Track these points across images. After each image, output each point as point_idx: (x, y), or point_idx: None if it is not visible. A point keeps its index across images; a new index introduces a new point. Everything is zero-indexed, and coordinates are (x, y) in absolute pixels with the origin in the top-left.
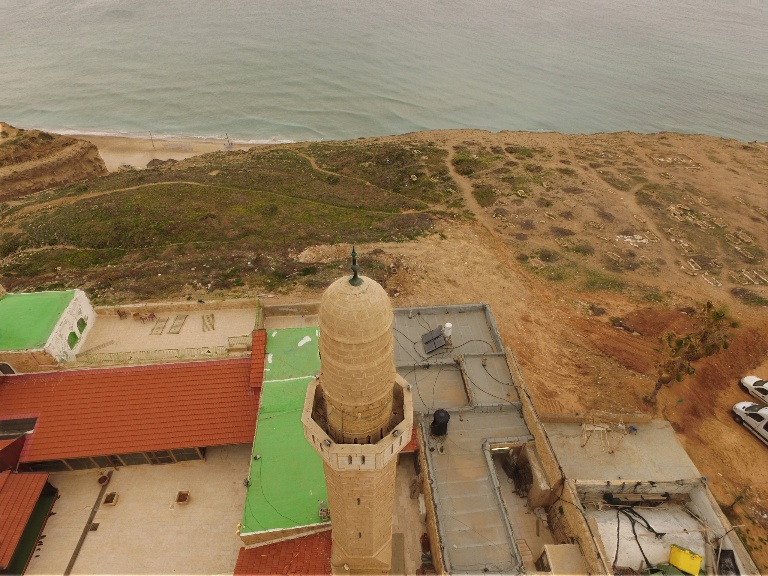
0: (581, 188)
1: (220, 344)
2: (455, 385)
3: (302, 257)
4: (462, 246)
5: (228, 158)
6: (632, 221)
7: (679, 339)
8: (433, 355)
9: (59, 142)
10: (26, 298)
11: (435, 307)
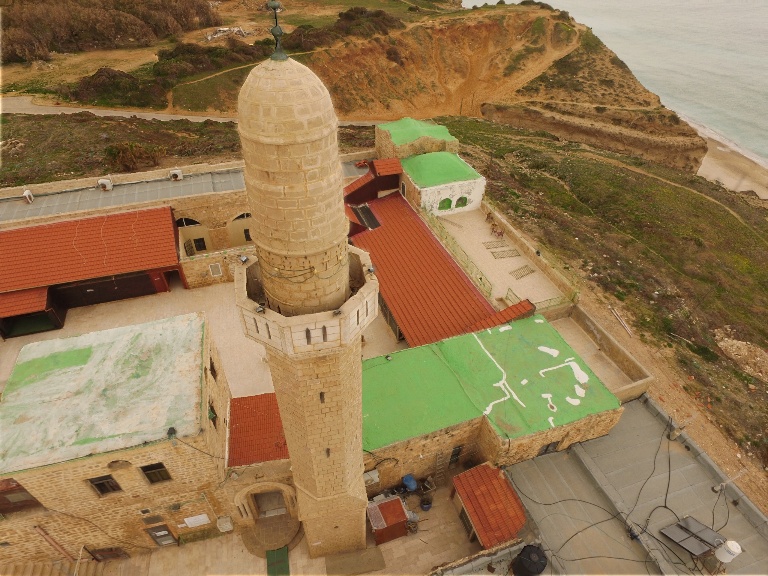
0: None
1: (503, 290)
2: None
3: (727, 342)
4: None
5: None
6: None
7: None
8: (665, 544)
9: (680, 129)
10: (453, 158)
11: None
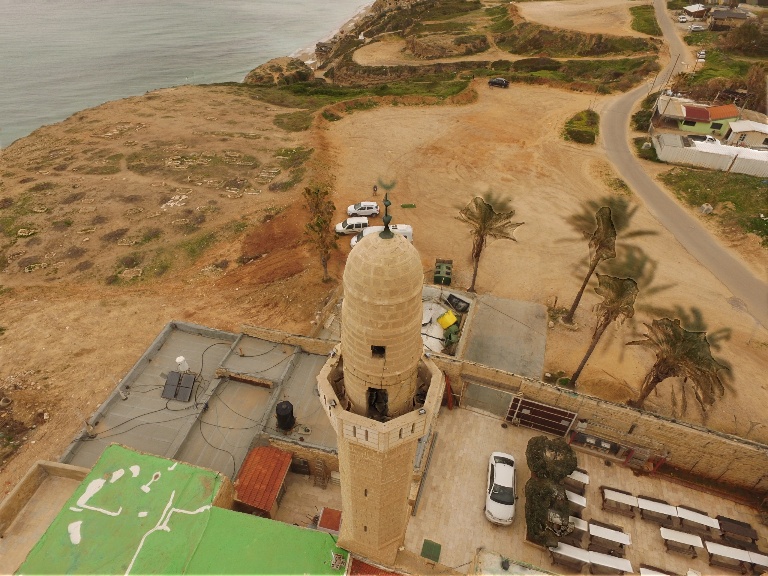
0: (78, 192)
1: None
2: (244, 391)
3: None
4: (37, 320)
5: None
6: (156, 190)
7: (316, 223)
8: (195, 396)
9: None
10: None
11: (135, 366)
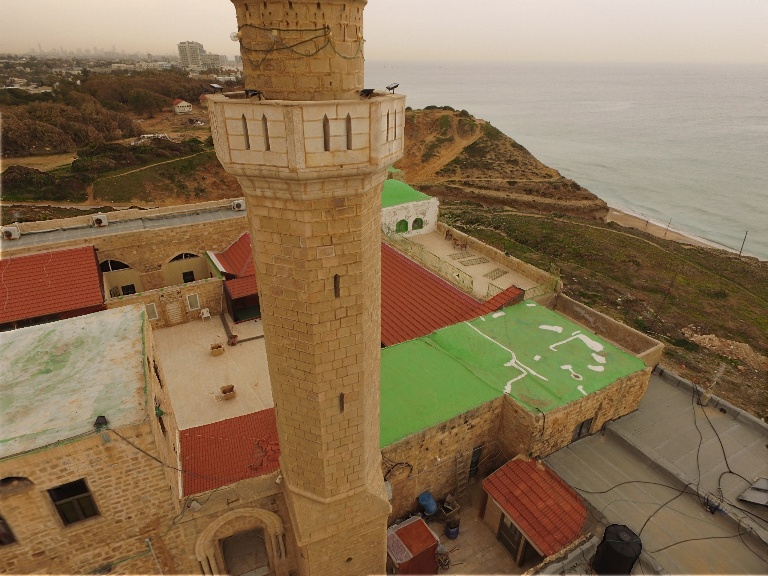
0: None
1: (482, 289)
2: None
3: (698, 337)
4: None
5: (728, 255)
6: None
7: None
8: (750, 512)
9: (582, 194)
10: (403, 183)
11: None
